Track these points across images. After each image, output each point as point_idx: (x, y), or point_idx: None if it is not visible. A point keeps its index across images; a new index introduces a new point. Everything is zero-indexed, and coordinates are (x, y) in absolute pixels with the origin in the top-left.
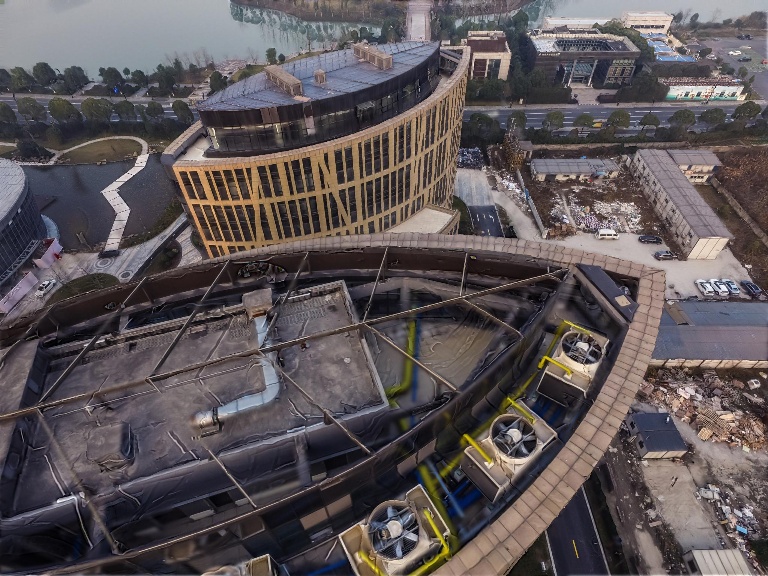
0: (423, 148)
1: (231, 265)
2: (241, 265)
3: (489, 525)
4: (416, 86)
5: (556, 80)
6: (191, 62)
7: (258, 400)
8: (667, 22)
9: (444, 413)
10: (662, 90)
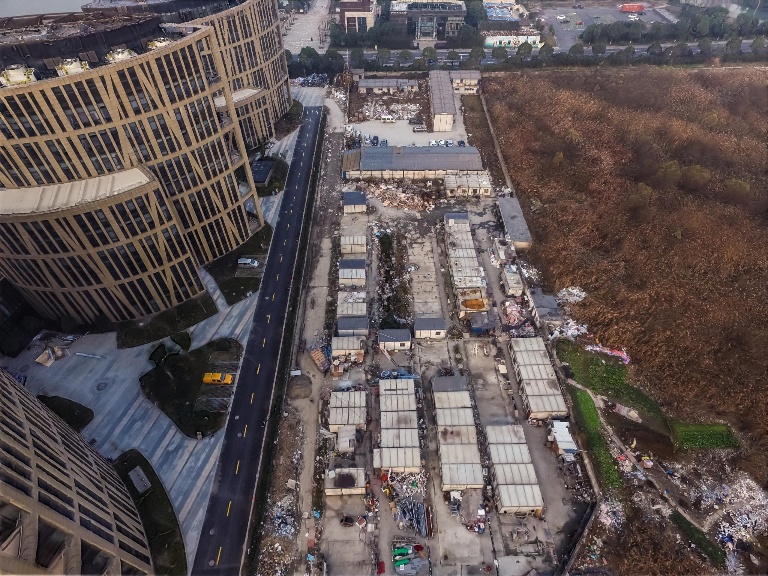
0: (230, 42)
1: (44, 16)
2: (48, 17)
3: (101, 66)
4: (227, 5)
5: (410, 34)
6: None
7: (37, 35)
8: None
9: (91, 36)
10: (479, 39)
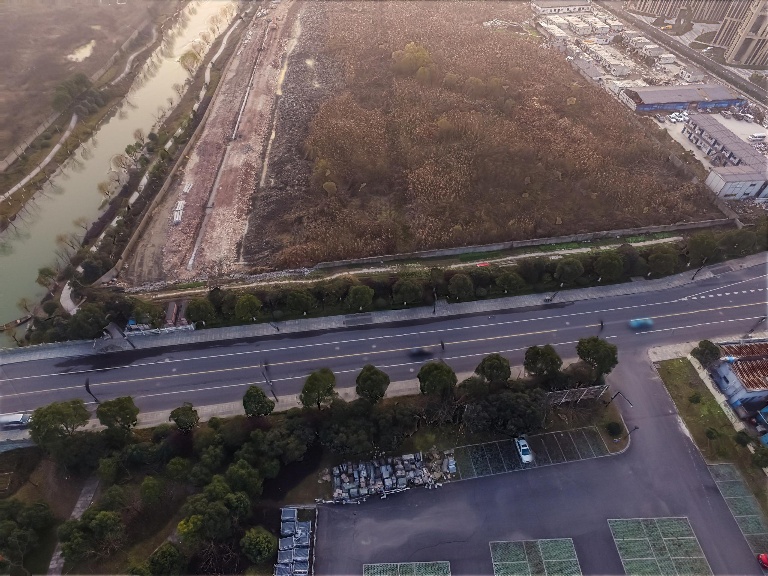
0: None
1: None
2: None
3: None
4: None
5: None
6: None
7: None
8: None
9: None
10: None
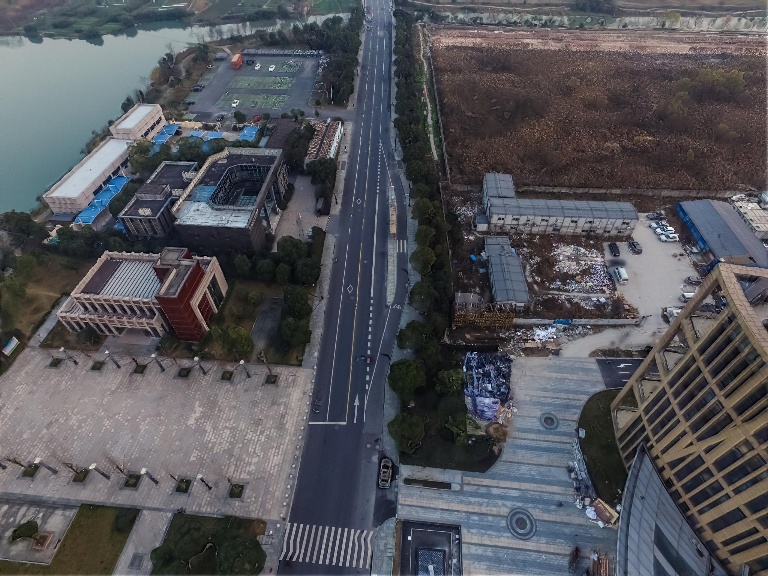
0: None
1: None
2: None
3: None
4: None
5: None
6: None
7: None
8: (160, 112)
9: None
10: (335, 165)
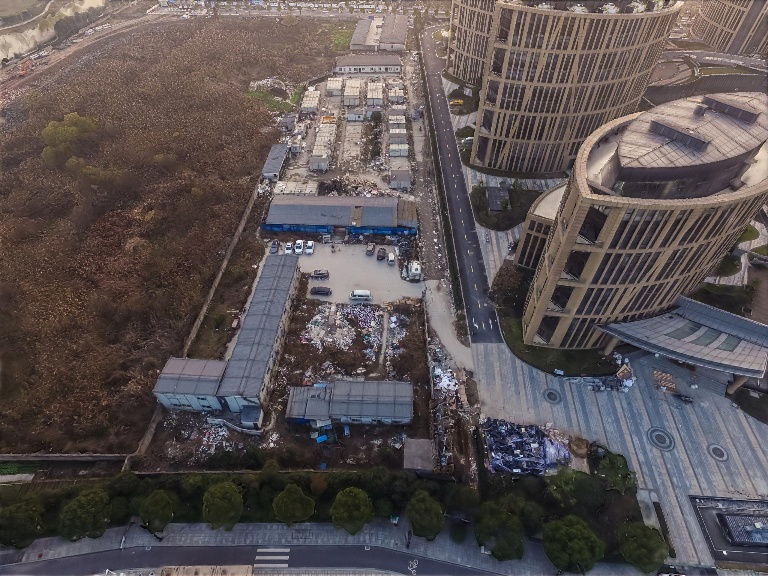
0: None
1: None
2: None
3: None
4: None
5: None
6: None
7: None
8: None
9: None
10: None
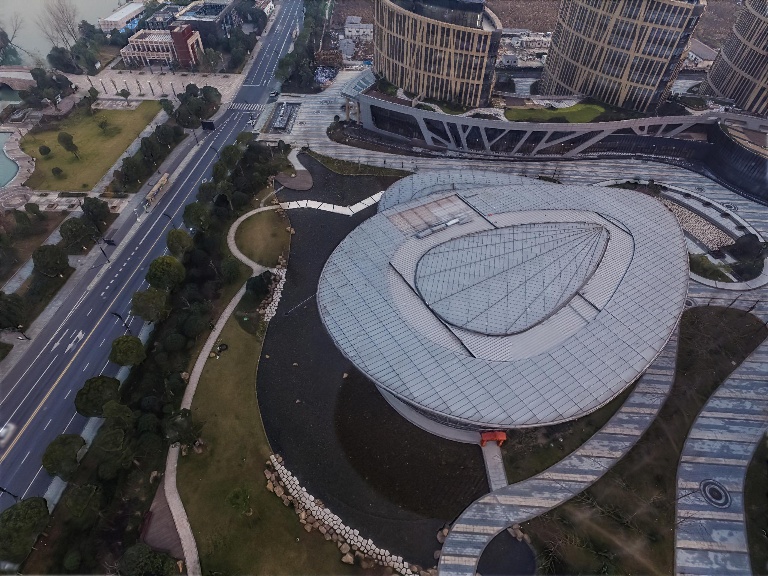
0: None
1: None
2: None
3: None
4: None
5: None
6: (4, 213)
7: None
8: None
9: None
10: None
